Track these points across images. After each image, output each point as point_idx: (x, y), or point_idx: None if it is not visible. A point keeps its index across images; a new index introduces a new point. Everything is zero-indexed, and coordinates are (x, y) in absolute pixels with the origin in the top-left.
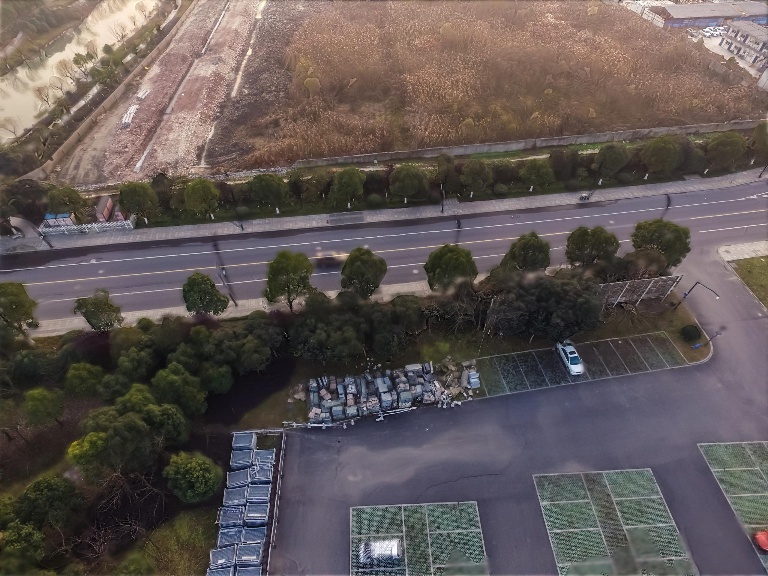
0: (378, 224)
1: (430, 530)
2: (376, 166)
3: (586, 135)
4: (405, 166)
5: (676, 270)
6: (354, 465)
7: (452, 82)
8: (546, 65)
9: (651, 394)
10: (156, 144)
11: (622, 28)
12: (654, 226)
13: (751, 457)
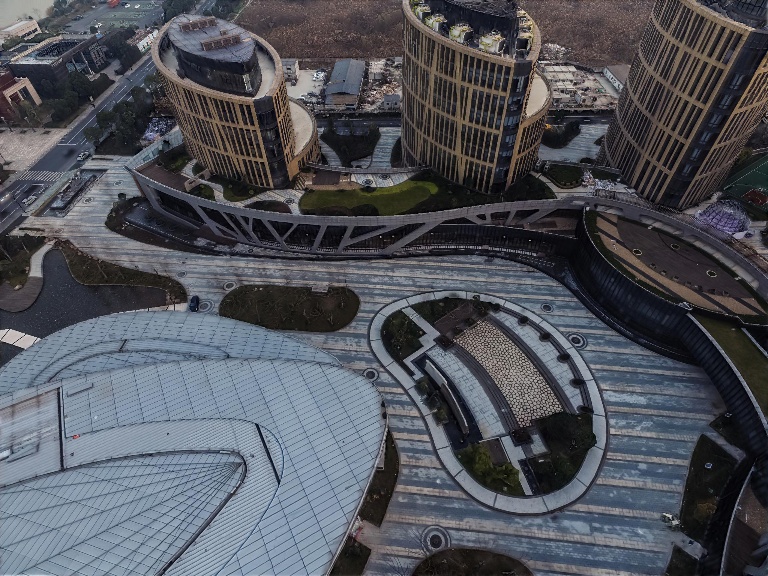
0: None
1: (153, 6)
2: None
3: None
4: None
5: None
6: None
7: None
8: None
9: None
10: None
11: None
12: None
13: None
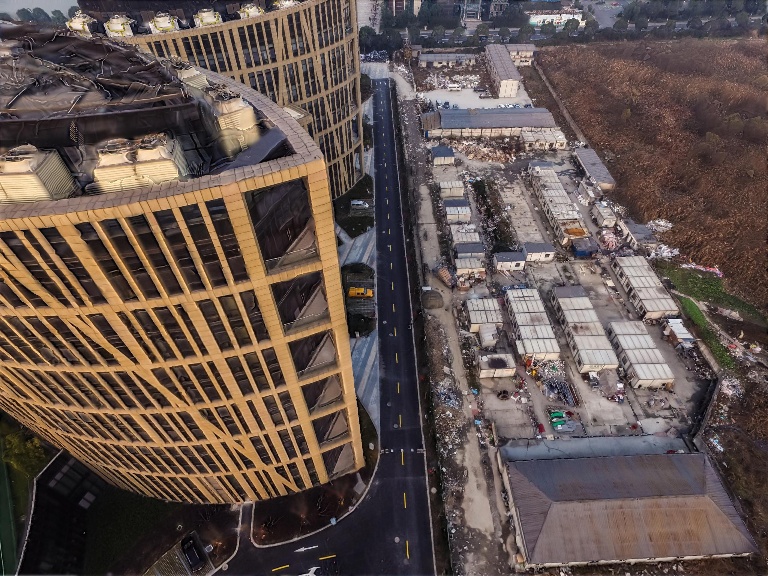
0: None
1: None
2: None
3: (644, 43)
4: (725, 18)
5: None
6: None
7: None
8: (674, 53)
9: None
10: None
11: (598, 104)
12: (639, 4)
13: (614, 8)
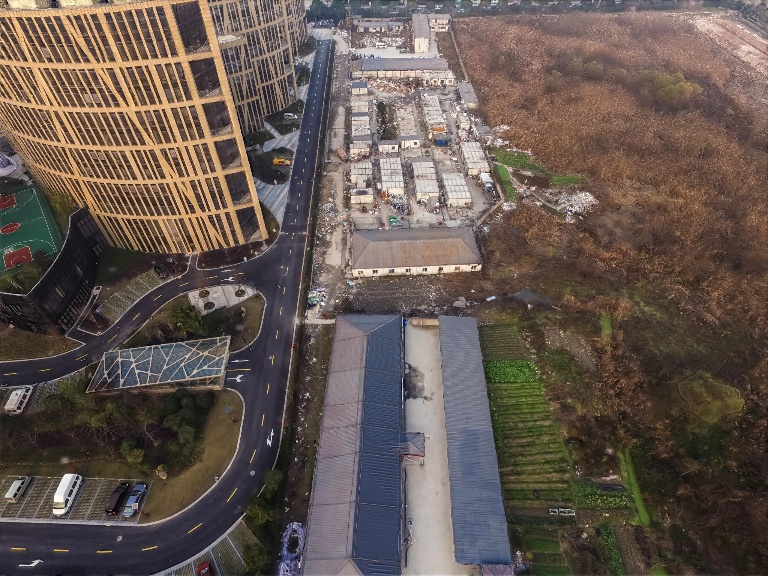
0: None
1: None
2: None
3: None
4: None
5: None
6: None
7: None
8: None
9: None
10: (713, 22)
11: (487, 56)
12: None
13: None
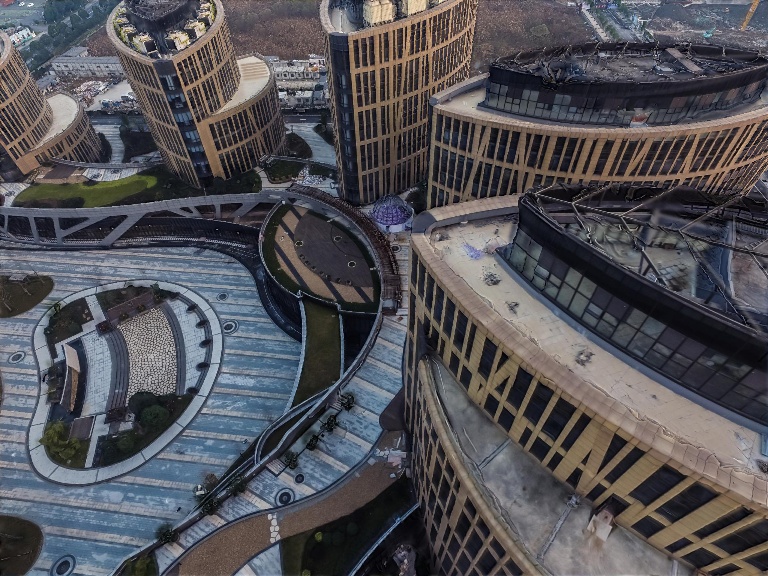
0: None
1: None
2: None
3: None
4: None
5: None
6: None
7: None
8: None
9: (35, 18)
10: None
11: None
12: (51, 6)
13: None
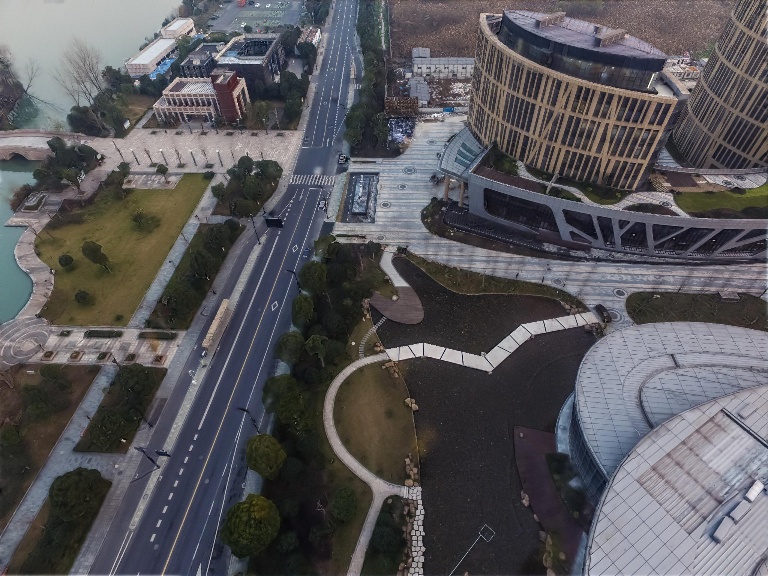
0: (357, 4)
1: None
2: (384, 4)
3: None
4: None
5: (323, 28)
6: (297, 2)
7: (434, 8)
8: (437, 14)
9: None
10: None
11: None
12: None
13: None
